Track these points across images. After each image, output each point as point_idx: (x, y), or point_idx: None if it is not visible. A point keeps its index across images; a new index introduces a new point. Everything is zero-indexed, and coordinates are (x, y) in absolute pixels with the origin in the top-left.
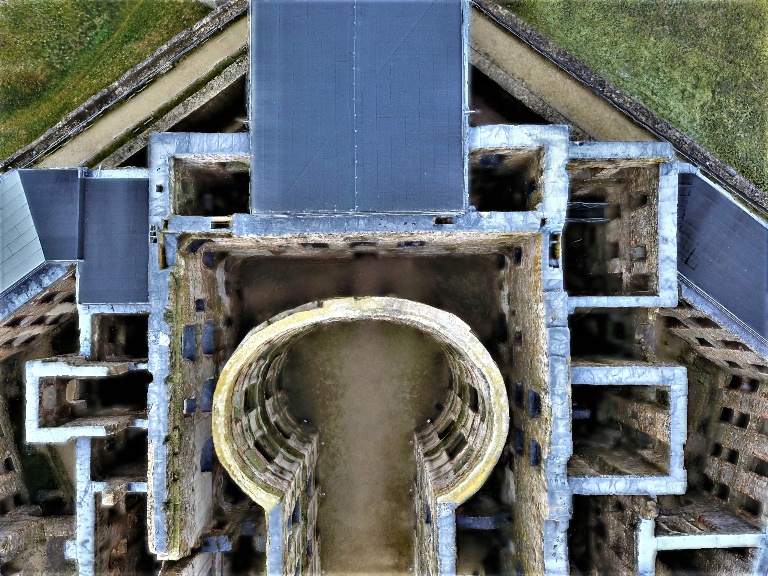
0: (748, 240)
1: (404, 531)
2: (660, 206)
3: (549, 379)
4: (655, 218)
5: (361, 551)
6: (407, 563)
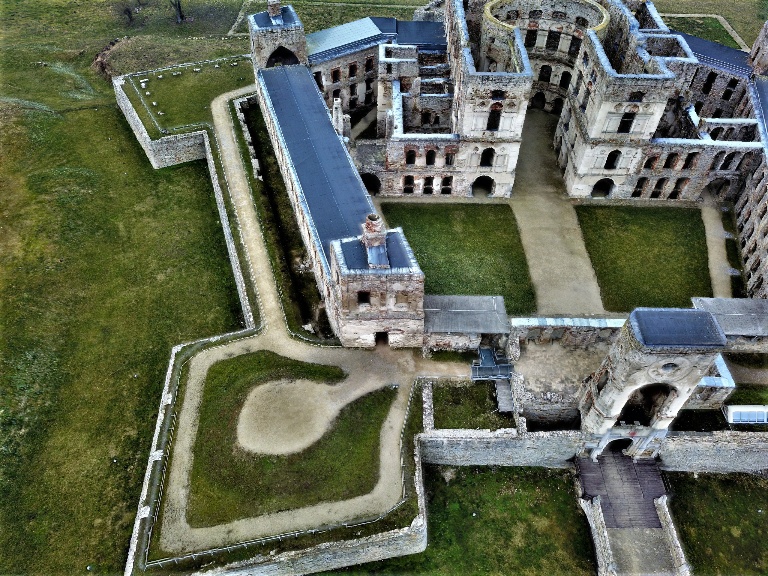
0: (695, 40)
1: (557, 179)
2: (650, 11)
3: (622, 10)
4: (649, 15)
5: (532, 186)
6: (562, 191)
